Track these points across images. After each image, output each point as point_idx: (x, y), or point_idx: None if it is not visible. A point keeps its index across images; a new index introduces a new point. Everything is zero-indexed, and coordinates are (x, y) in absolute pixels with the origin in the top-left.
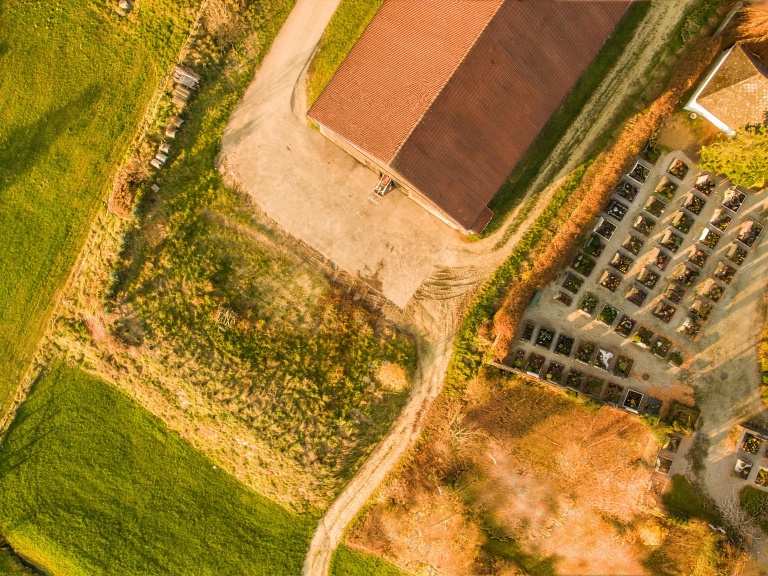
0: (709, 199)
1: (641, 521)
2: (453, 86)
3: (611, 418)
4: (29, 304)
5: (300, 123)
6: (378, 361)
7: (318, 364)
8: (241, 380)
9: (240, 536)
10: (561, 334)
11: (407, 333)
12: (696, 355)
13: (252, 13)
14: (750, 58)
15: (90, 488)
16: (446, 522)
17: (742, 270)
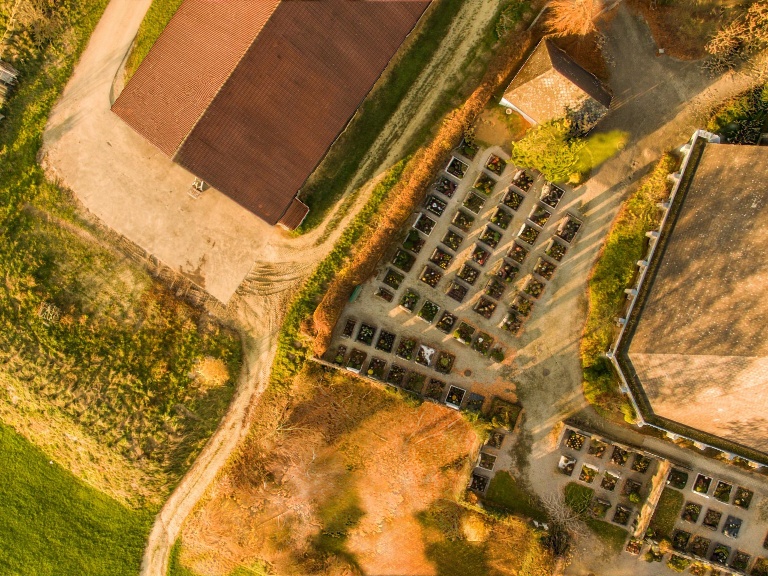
0: (528, 195)
1: (465, 517)
2: (236, 81)
3: (438, 414)
4: None
5: (120, 119)
6: (201, 356)
7: (142, 359)
8: (66, 375)
9: (79, 531)
10: (383, 330)
11: (231, 329)
12: (518, 351)
13: (68, 9)
14: (552, 53)
15: None
16: (279, 518)
17: (562, 266)
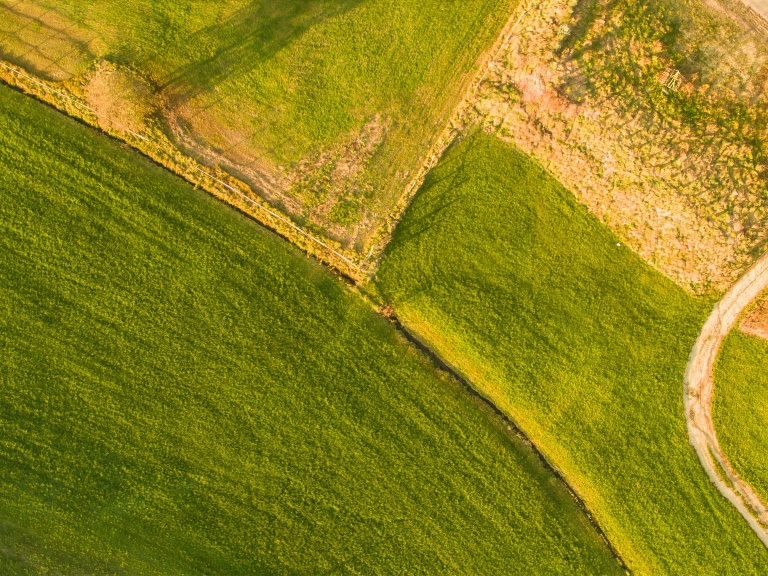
0: None
1: None
2: None
3: None
4: (451, 66)
5: None
6: None
7: (756, 132)
8: (678, 145)
9: (634, 317)
10: None
11: None
12: None
13: None
14: None
15: (488, 261)
16: None
17: None
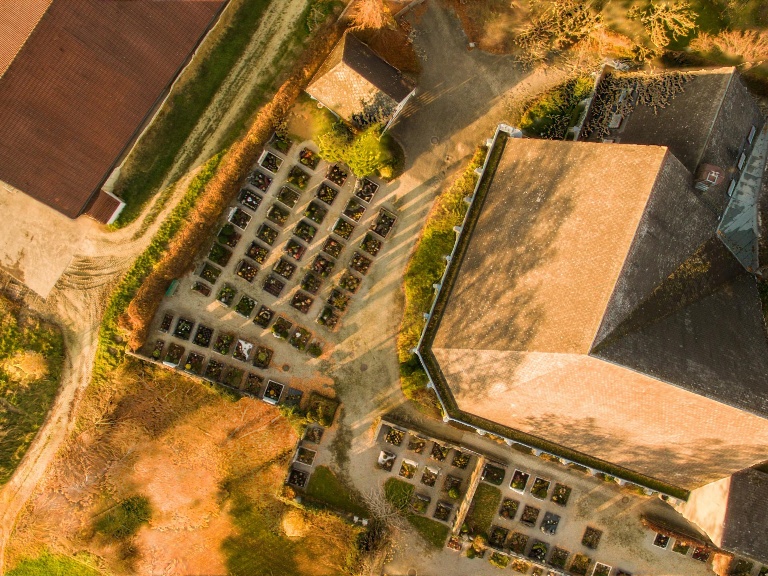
0: (342, 189)
1: (285, 512)
2: (16, 74)
3: (262, 409)
4: None
5: None
6: (21, 350)
7: None
8: None
9: None
10: (200, 324)
11: (52, 323)
12: (336, 346)
13: None
14: (349, 46)
15: None
16: (108, 512)
17: (378, 261)
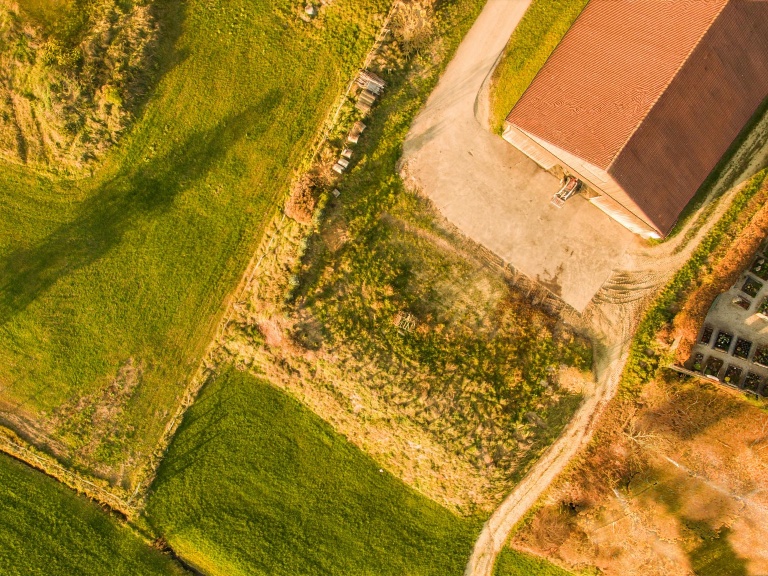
0: None
1: None
2: (670, 92)
3: None
4: (199, 308)
5: (482, 128)
6: (556, 365)
7: (497, 368)
8: (419, 384)
9: (404, 539)
10: (739, 337)
11: (584, 337)
12: None
13: (439, 19)
14: None
15: (255, 492)
16: (614, 524)
17: None
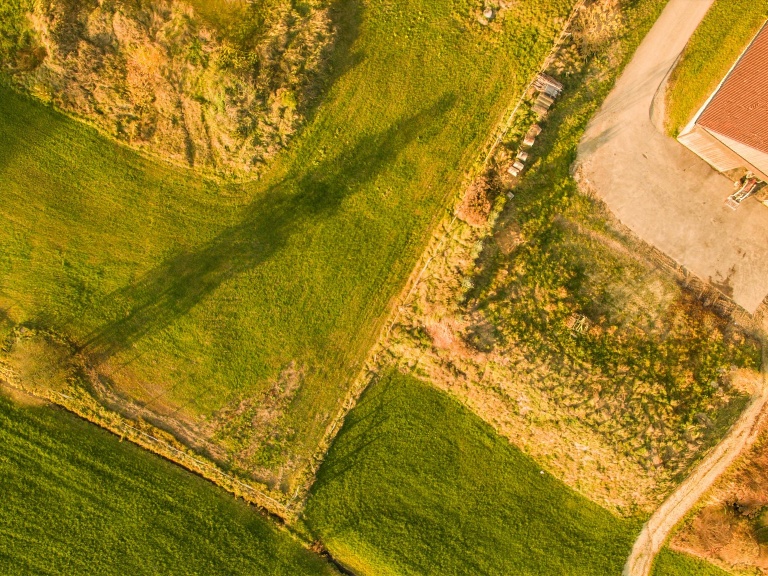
0: None
1: None
2: None
3: None
4: (363, 311)
5: (657, 131)
6: (727, 366)
7: (668, 369)
8: (590, 386)
9: (563, 540)
10: None
11: (754, 338)
12: None
13: (618, 22)
14: None
15: (414, 494)
16: None
17: None
